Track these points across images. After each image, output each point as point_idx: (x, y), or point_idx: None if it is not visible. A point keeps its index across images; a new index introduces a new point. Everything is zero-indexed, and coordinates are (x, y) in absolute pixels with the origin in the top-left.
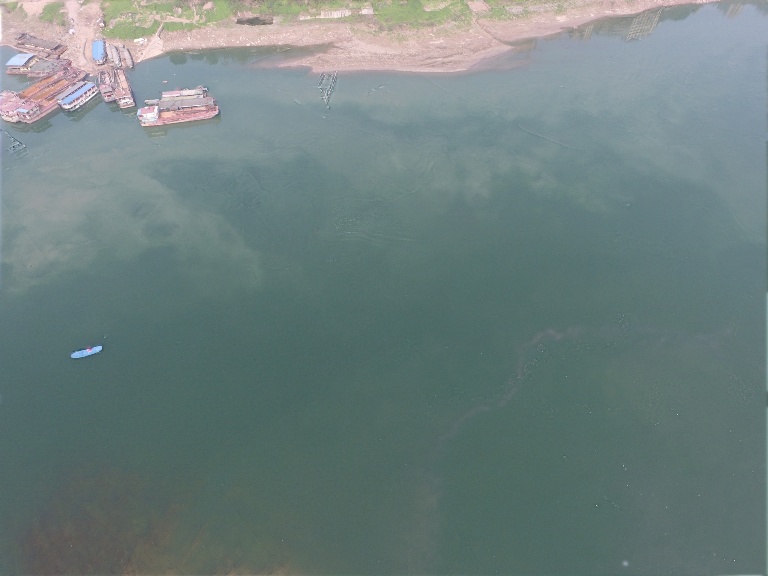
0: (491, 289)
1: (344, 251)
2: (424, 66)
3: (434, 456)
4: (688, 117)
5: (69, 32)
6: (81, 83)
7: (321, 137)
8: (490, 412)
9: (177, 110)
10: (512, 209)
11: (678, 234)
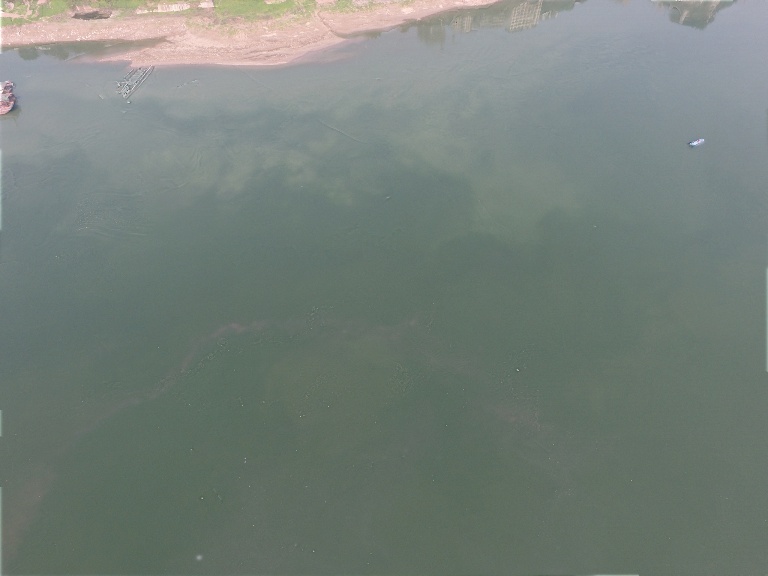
0: (202, 283)
1: (71, 246)
2: (245, 59)
3: (63, 451)
4: (491, 108)
5: None
6: None
7: (103, 132)
8: (137, 406)
9: None
10: (267, 203)
11: (414, 226)
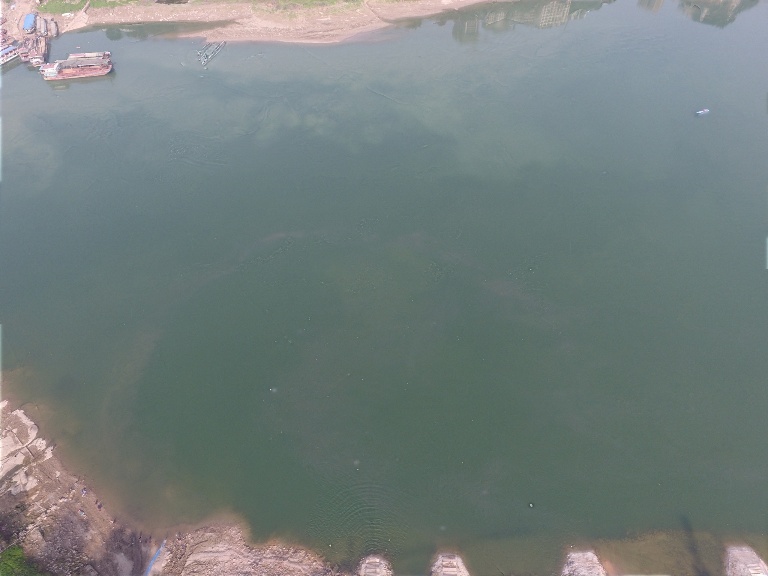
0: (272, 200)
1: (165, 171)
2: (304, 38)
3: (168, 306)
4: (518, 81)
5: (10, 7)
6: (5, 46)
7: (186, 89)
8: (224, 280)
9: (76, 67)
10: (323, 146)
11: (448, 165)
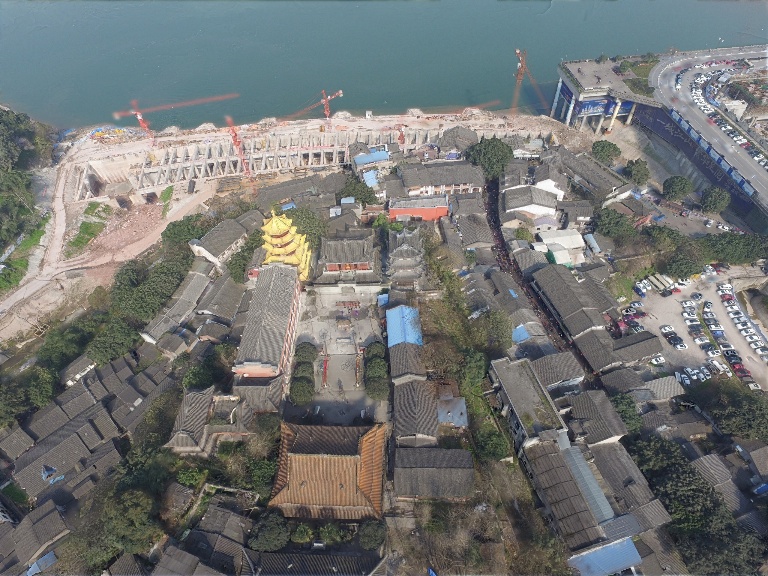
0: (146, 29)
1: (81, 22)
2: None
3: None
4: None
5: None
6: None
7: None
8: None
9: None
10: (185, 7)
11: (259, 7)
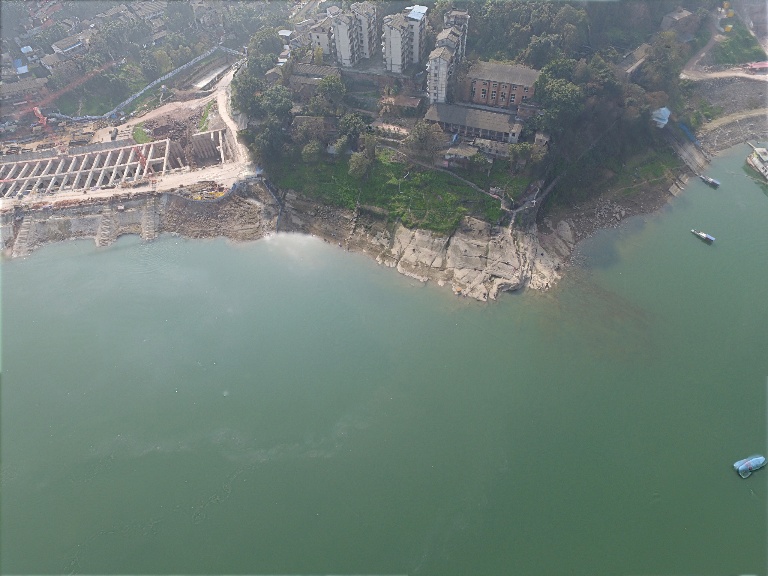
0: None
1: None
2: None
3: (342, 389)
4: None
5: None
6: None
7: None
8: (283, 430)
9: None
10: None
11: None
